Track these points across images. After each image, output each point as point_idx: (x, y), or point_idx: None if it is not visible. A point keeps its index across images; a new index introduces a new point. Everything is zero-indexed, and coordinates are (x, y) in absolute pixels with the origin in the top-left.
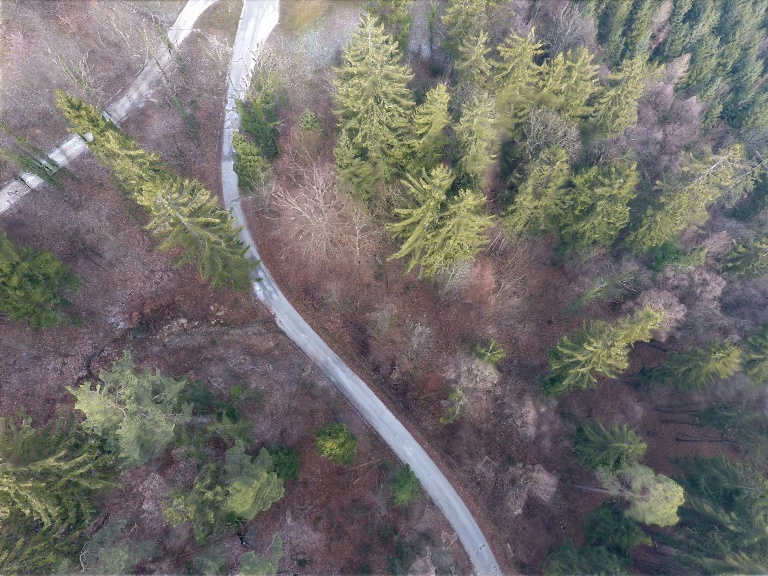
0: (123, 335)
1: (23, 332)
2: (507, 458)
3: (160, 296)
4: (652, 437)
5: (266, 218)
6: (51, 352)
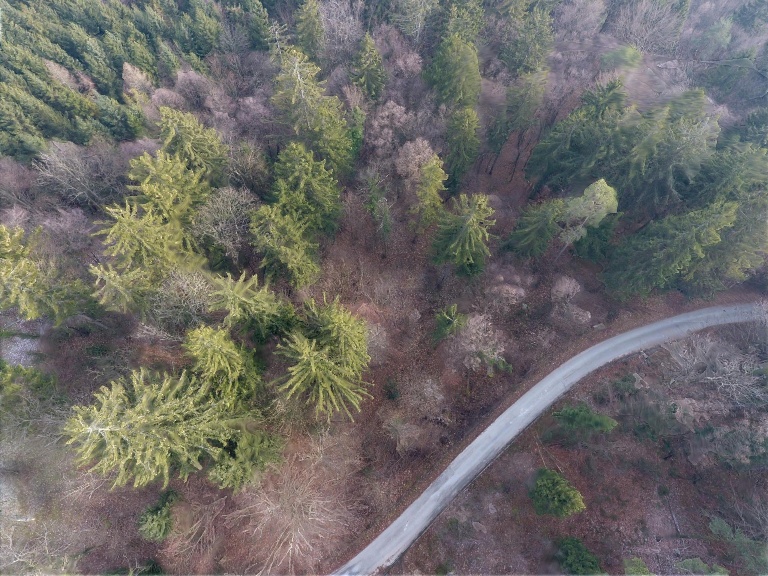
0: None
1: None
2: (519, 317)
3: None
4: (491, 192)
5: None
6: None
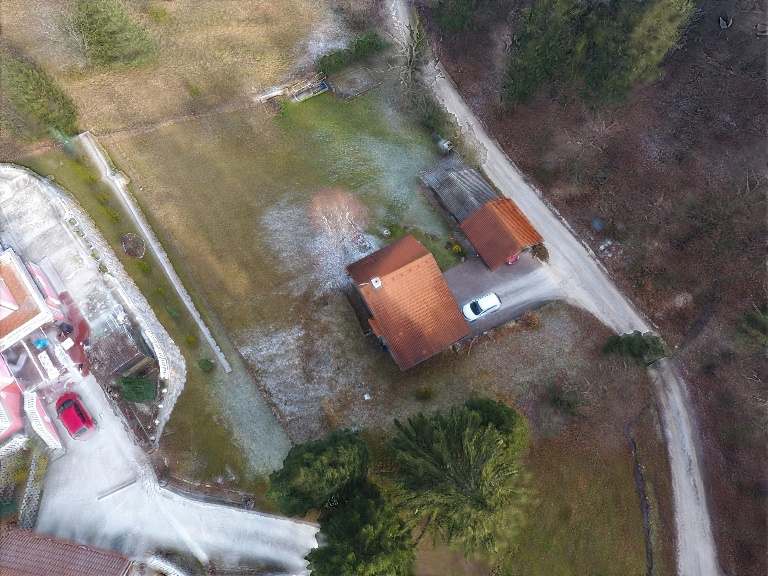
0: None
1: None
2: None
3: None
4: None
5: None
6: None
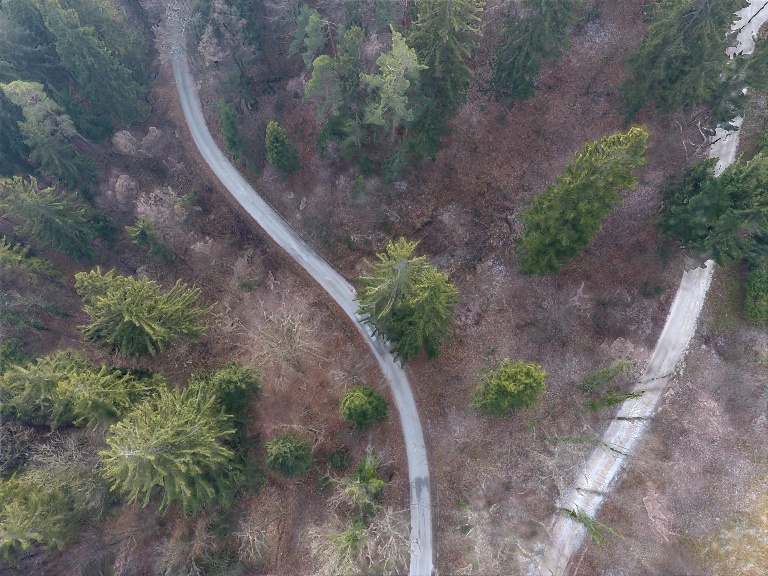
0: None
1: None
2: None
3: None
4: None
5: None
6: None
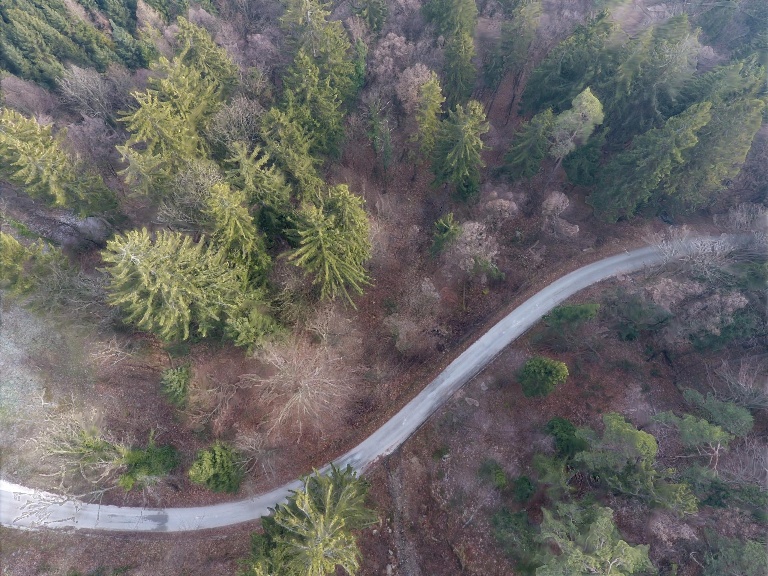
0: None
1: None
2: (512, 243)
3: None
4: None
5: (260, 466)
6: None
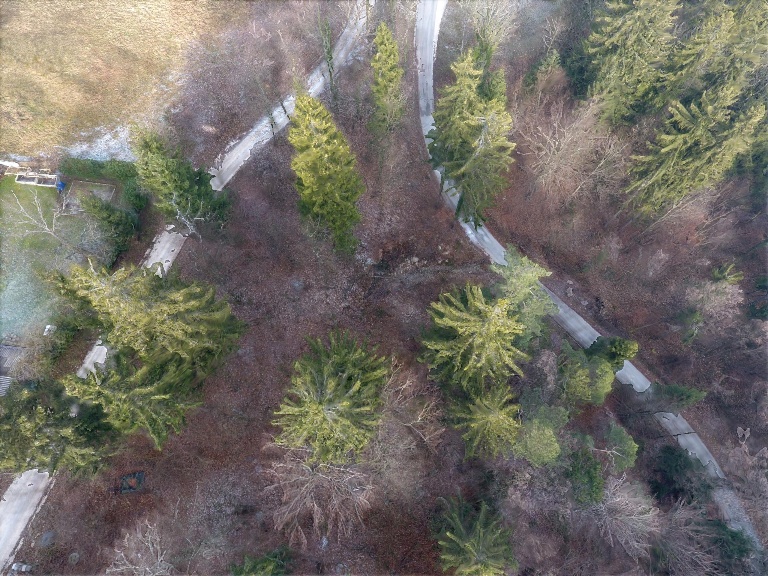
0: (369, 271)
1: (288, 266)
2: None
3: (395, 236)
4: None
5: None
6: (314, 285)
